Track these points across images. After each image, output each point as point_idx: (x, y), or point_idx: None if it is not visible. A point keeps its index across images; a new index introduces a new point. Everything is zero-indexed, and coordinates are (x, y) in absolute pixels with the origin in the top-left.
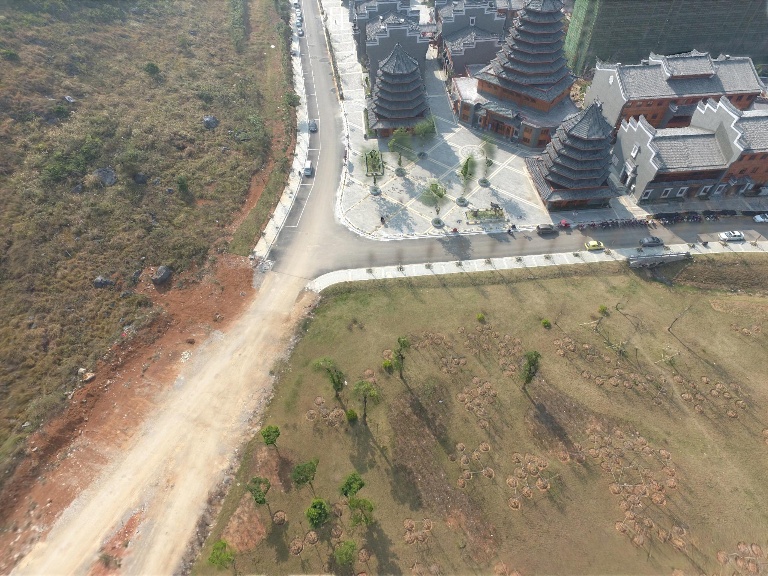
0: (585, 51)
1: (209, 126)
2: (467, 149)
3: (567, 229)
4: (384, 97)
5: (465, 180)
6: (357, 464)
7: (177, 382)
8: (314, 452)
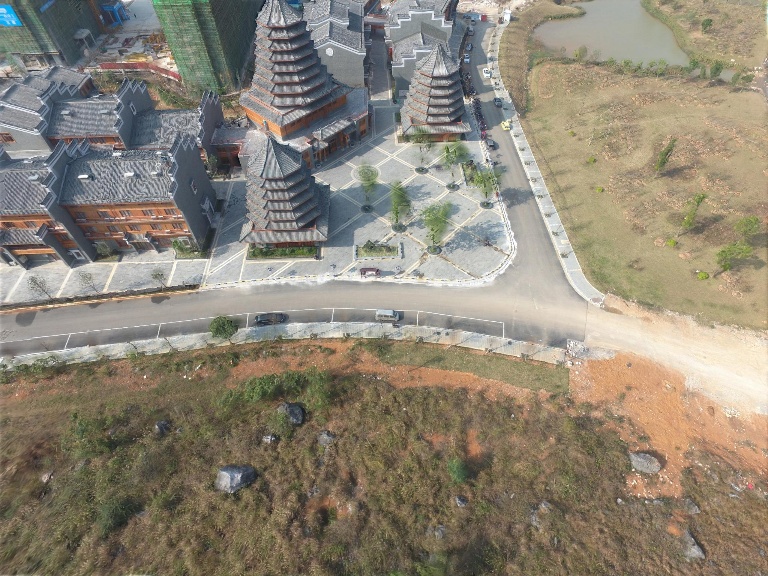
0: (225, 65)
1: (252, 476)
2: (359, 176)
3: (486, 135)
4: (304, 200)
5: (450, 167)
6: (760, 265)
7: (766, 412)
8: (767, 291)
